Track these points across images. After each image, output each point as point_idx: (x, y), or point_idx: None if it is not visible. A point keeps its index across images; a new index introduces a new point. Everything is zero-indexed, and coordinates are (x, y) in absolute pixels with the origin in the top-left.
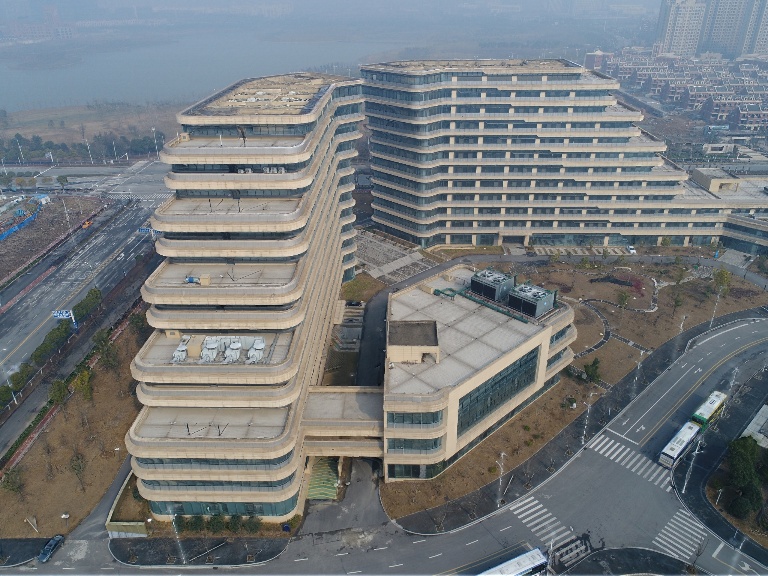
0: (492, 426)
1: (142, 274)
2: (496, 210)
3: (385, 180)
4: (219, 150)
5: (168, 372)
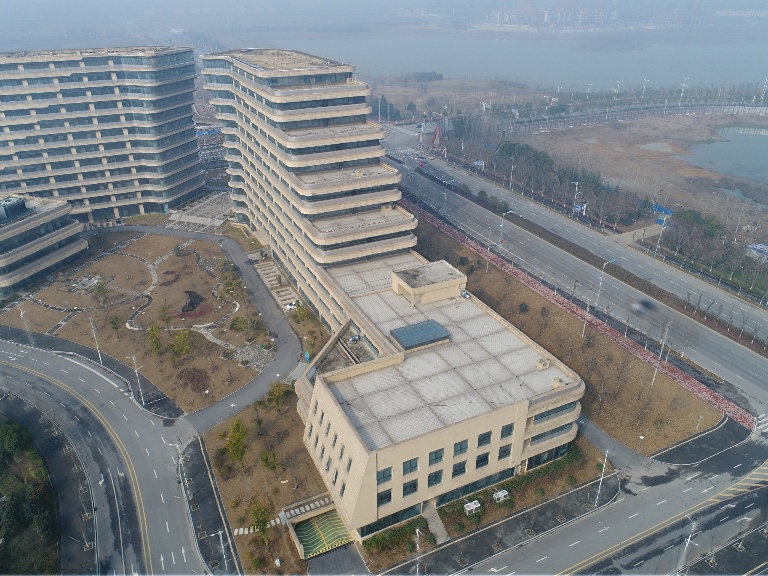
0: None
1: None
2: None
3: None
4: None
5: None
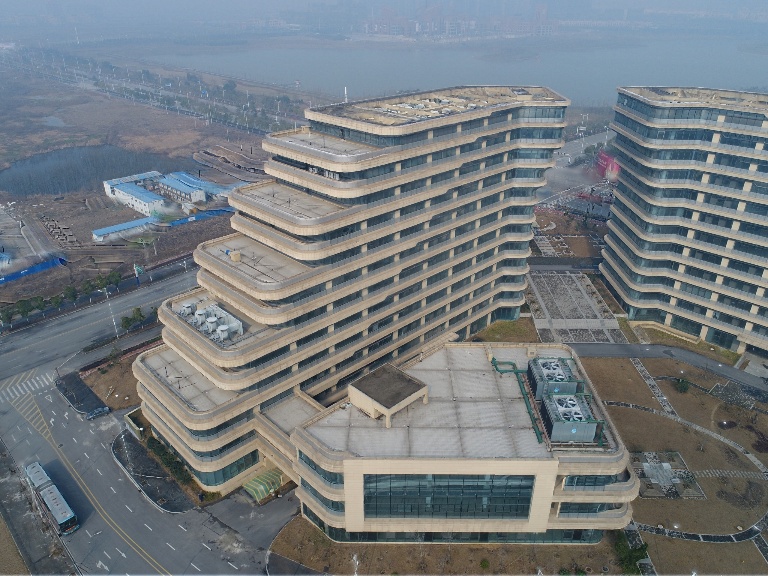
0: (438, 534)
1: None
2: (745, 305)
3: (617, 226)
4: (293, 145)
5: (171, 319)
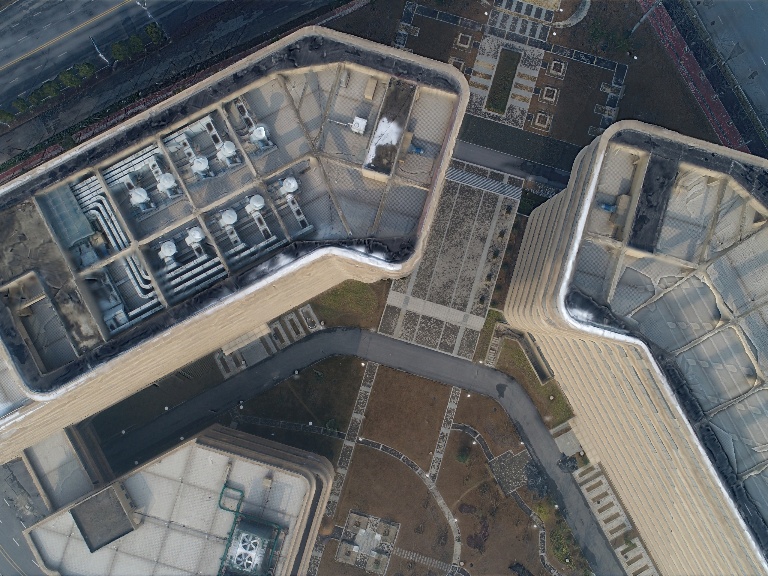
0: None
1: (258, 6)
2: None
3: None
4: None
5: None
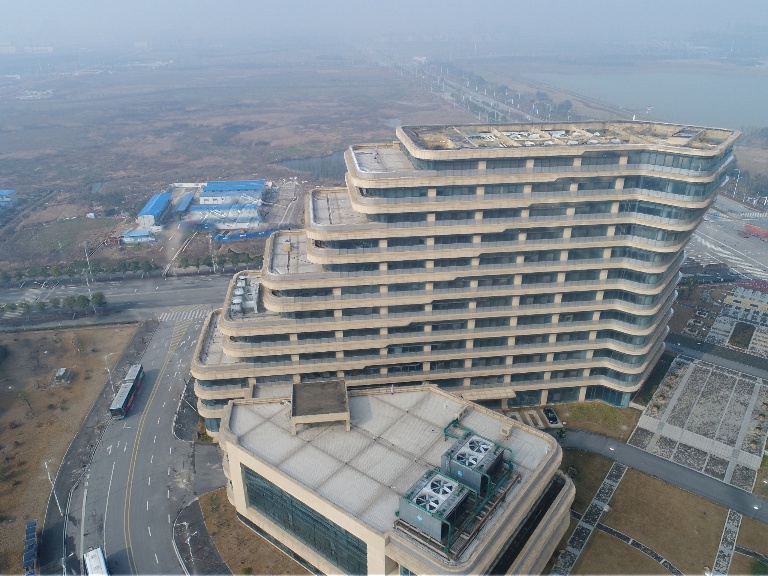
0: None
1: None
2: None
3: None
4: None
5: None
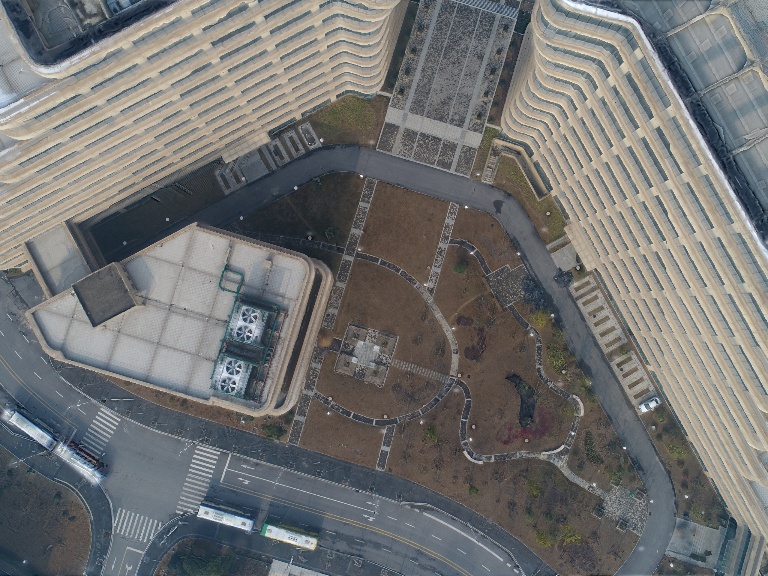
0: None
1: None
2: None
3: None
4: None
5: None
